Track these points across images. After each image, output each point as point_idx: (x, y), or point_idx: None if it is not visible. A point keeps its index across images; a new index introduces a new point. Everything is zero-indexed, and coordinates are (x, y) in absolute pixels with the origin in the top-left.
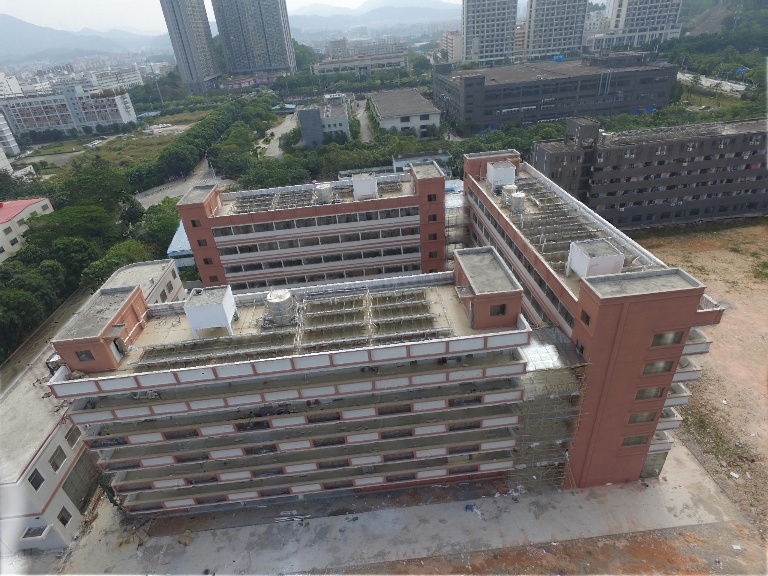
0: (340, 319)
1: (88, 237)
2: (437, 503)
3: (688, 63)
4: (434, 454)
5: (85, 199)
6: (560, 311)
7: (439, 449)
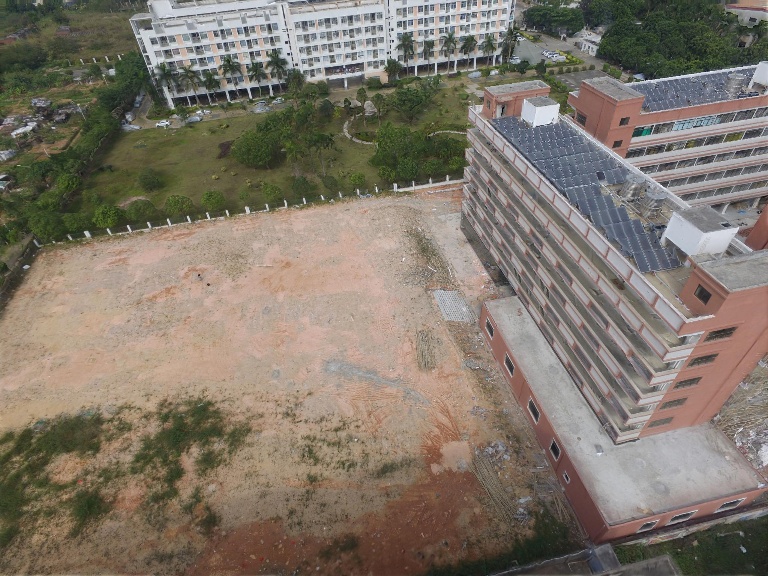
0: None
1: None
2: None
3: None
4: None
5: None
6: None
7: None
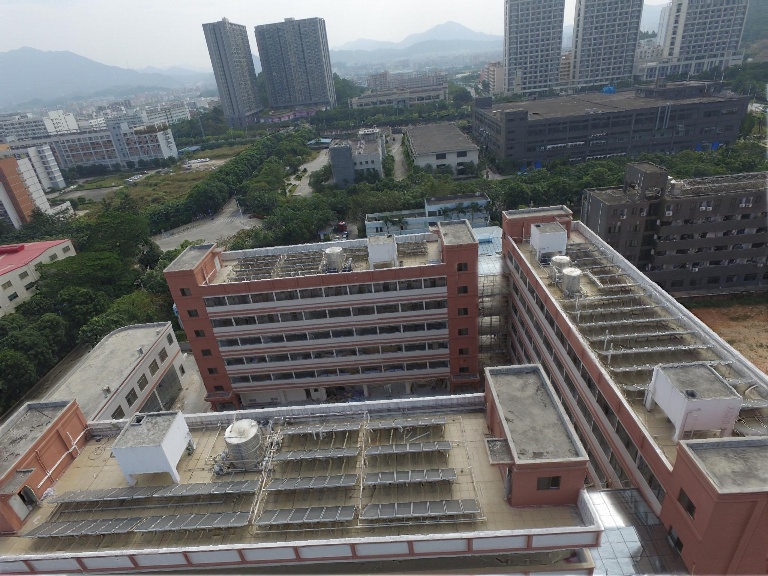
0: (323, 466)
1: (97, 286)
2: None
3: (755, 92)
4: None
5: (99, 245)
6: (640, 467)
7: None
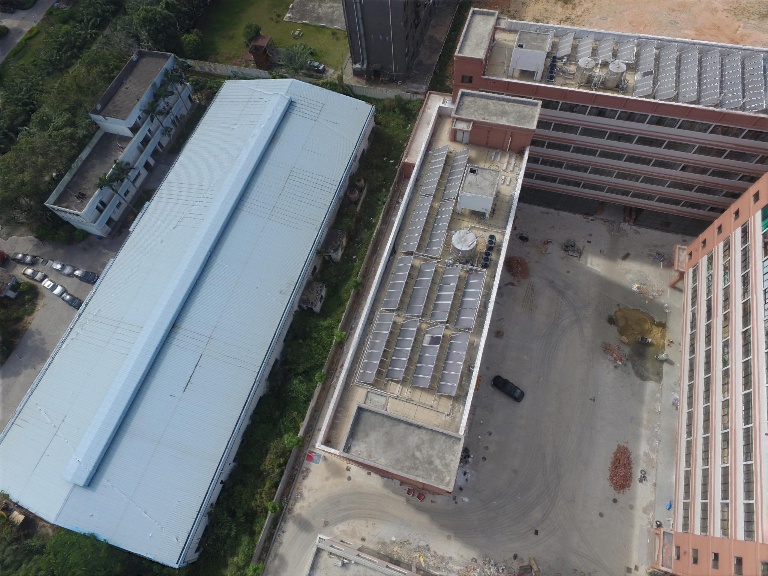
0: None
1: None
2: None
3: None
4: None
5: None
6: None
7: None
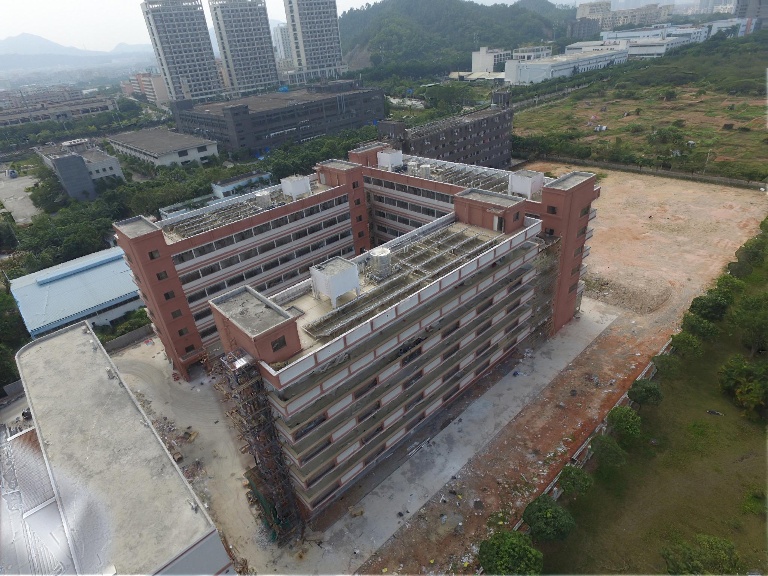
0: (422, 258)
1: None
2: (496, 383)
3: None
4: (498, 338)
5: None
6: None
7: (502, 332)
